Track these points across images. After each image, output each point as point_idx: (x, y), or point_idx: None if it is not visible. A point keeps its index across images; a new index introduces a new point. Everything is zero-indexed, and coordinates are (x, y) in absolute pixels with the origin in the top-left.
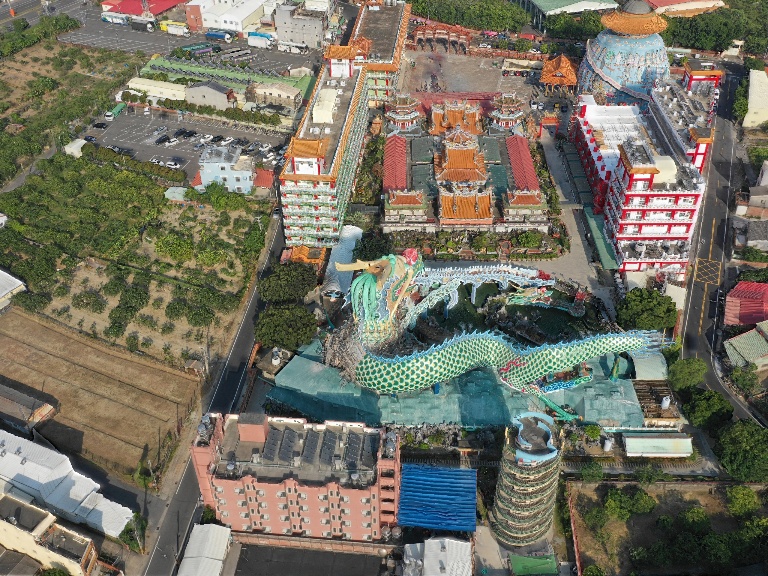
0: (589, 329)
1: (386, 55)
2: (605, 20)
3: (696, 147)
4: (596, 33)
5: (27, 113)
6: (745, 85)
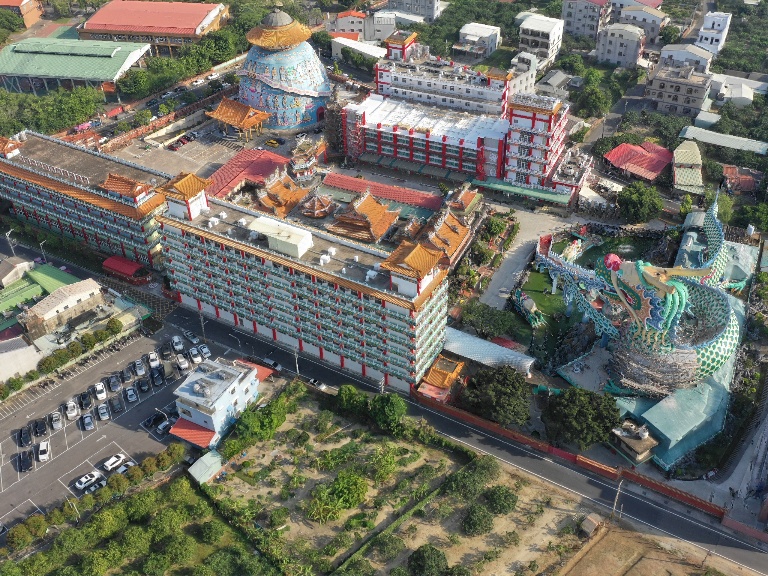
0: (617, 245)
1: (151, 178)
2: (263, 43)
3: (506, 85)
4: (176, 75)
5: None
6: (351, 51)
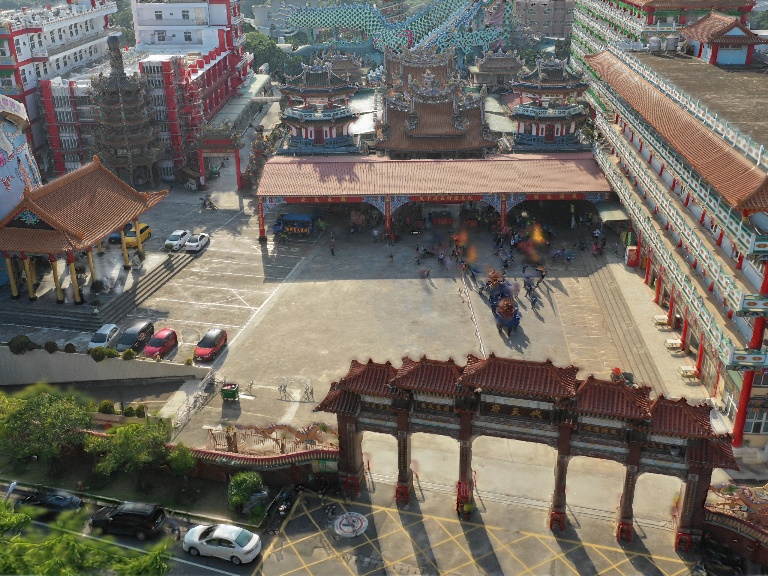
0: None
1: (642, 57)
2: None
3: None
4: None
5: None
6: None
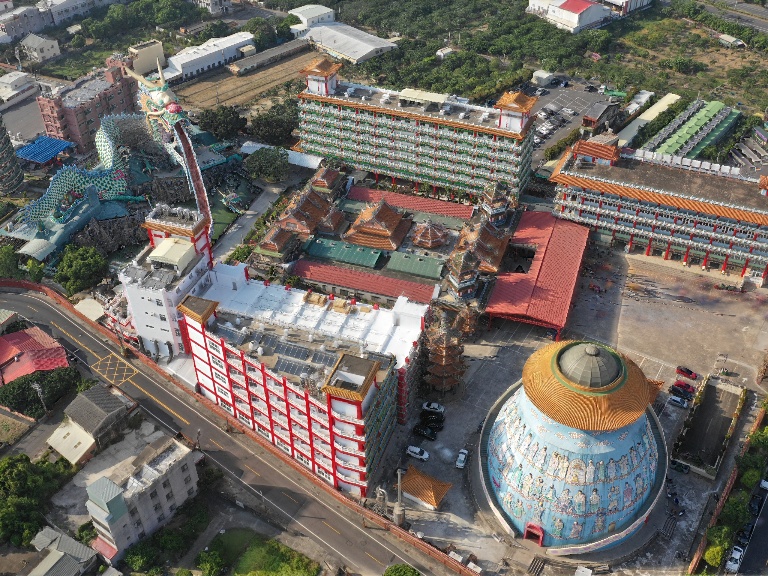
0: None
1: (588, 173)
2: None
3: None
4: None
5: (632, 64)
6: None
